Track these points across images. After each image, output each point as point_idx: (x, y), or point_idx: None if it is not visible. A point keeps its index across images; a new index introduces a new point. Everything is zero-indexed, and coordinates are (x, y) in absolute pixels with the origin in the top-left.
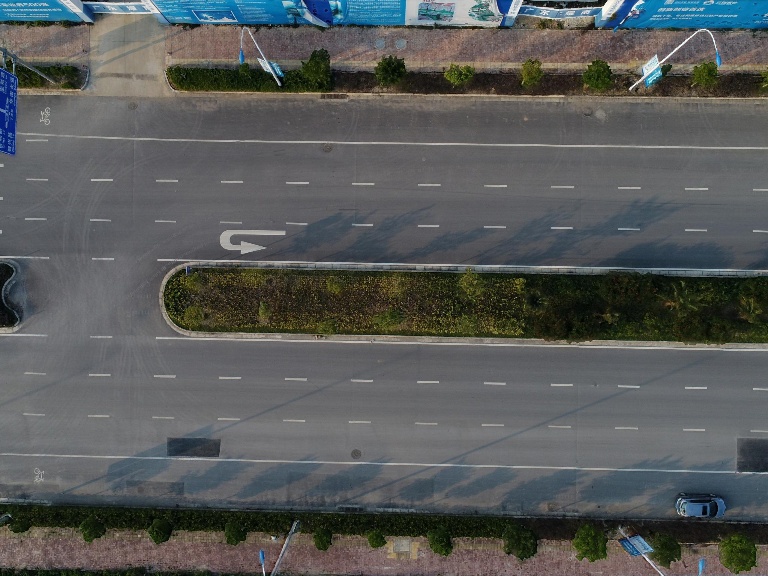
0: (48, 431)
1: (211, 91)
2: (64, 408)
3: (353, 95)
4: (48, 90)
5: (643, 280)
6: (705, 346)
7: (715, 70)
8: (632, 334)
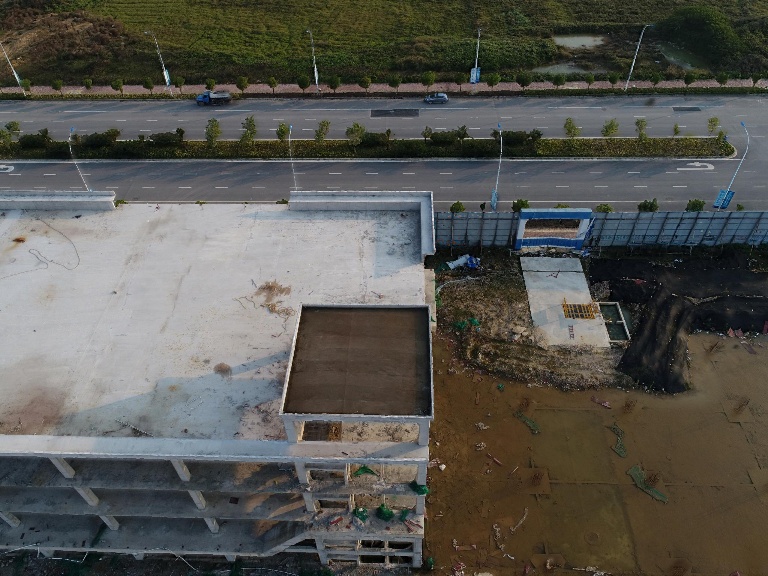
0: (765, 111)
1: None
2: (762, 117)
3: None
4: None
5: (479, 146)
6: None
7: (455, 205)
8: None
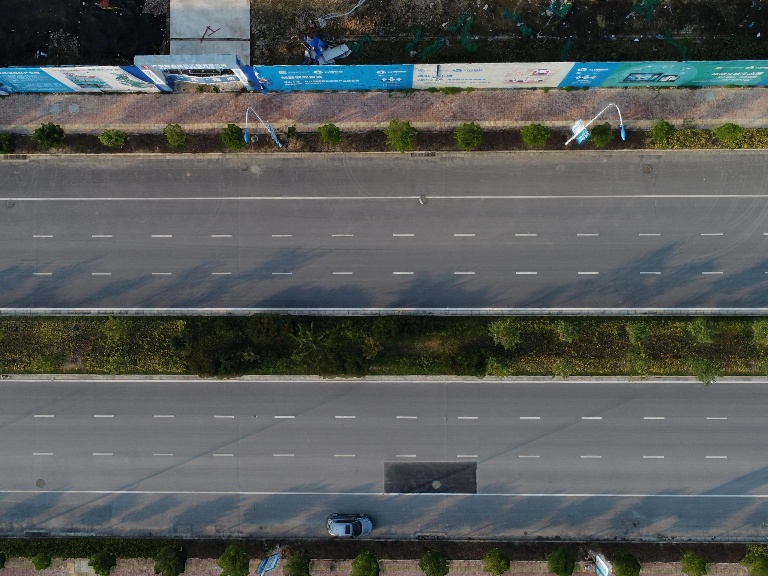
0: None
1: None
2: None
3: (33, 156)
4: None
5: (282, 321)
6: (352, 379)
7: (334, 131)
8: (283, 369)
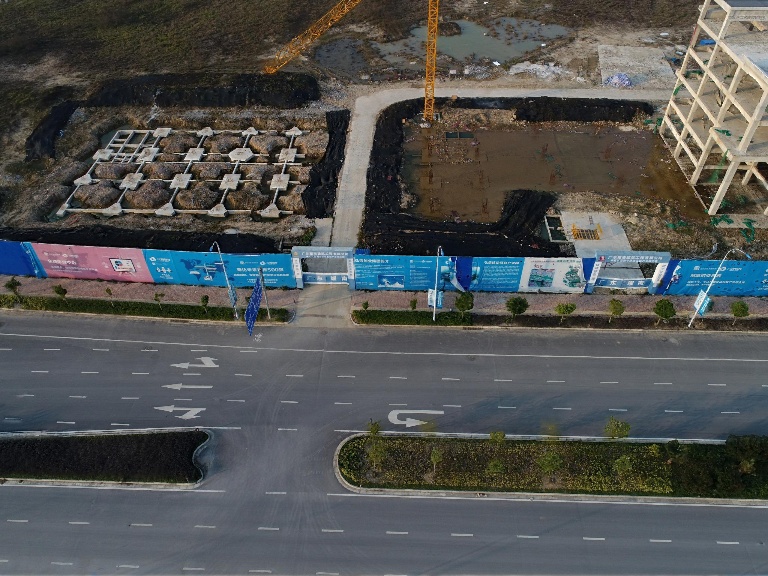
0: None
1: (383, 324)
2: (226, 562)
3: (487, 328)
4: (263, 323)
5: (762, 439)
6: None
7: (746, 305)
8: None
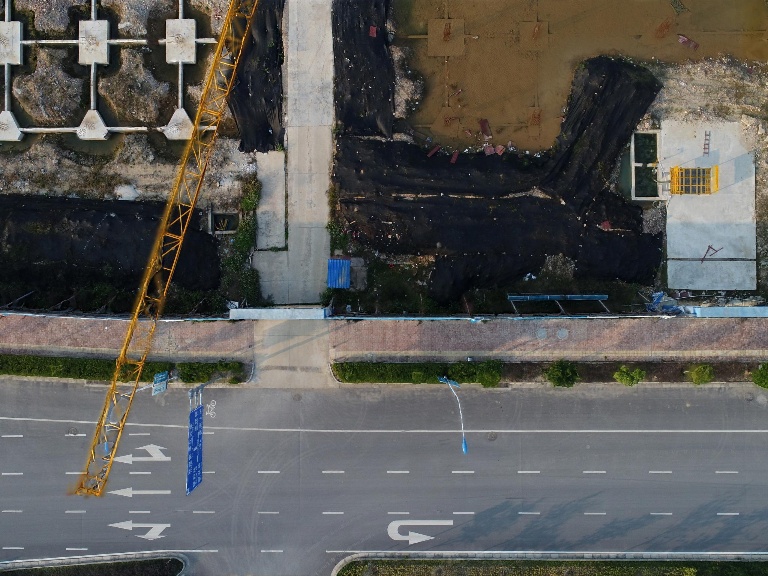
0: None
1: (375, 383)
2: None
3: (516, 384)
4: (213, 383)
5: None
6: None
7: None
8: None
